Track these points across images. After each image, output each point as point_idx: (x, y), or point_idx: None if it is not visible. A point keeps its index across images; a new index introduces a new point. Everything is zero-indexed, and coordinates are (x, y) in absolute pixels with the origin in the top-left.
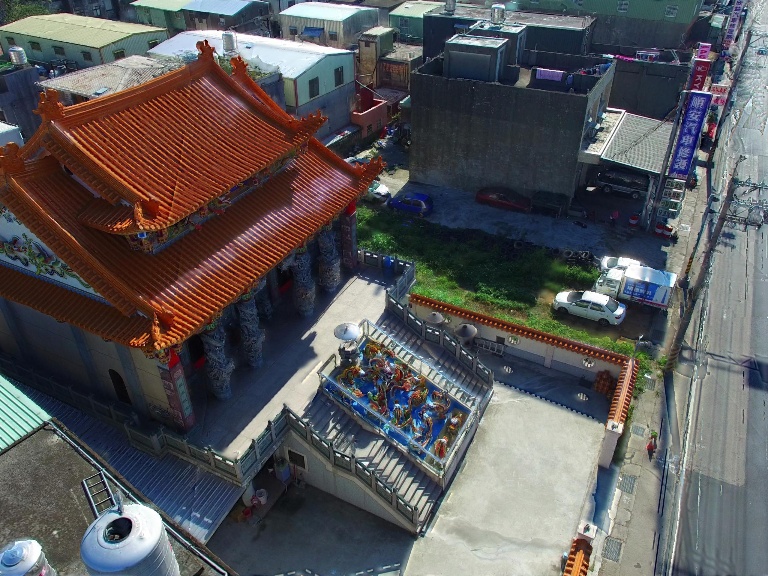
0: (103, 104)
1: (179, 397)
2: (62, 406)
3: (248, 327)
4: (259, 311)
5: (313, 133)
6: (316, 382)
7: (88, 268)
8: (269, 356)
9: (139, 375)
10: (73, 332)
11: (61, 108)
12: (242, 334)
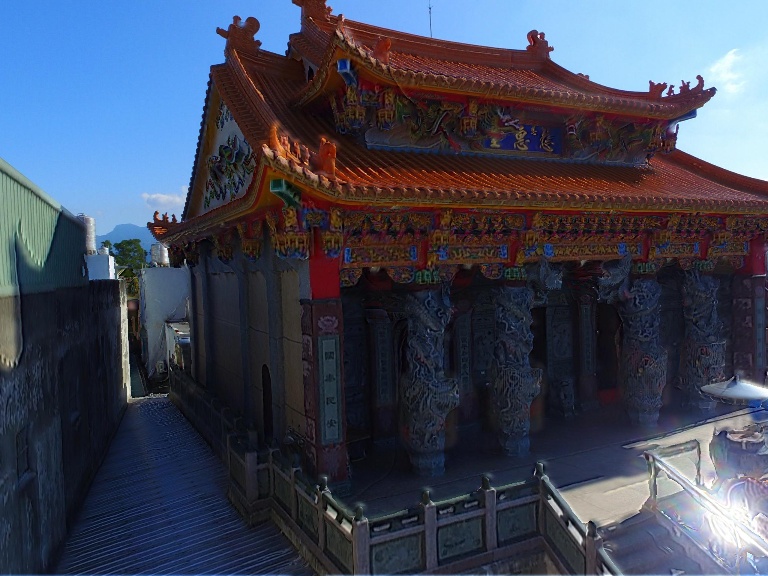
0: (384, 35)
1: (319, 382)
2: (199, 443)
3: (507, 345)
4: (549, 397)
5: (686, 107)
6: (640, 498)
7: (261, 129)
8: (545, 449)
9: (285, 356)
10: (239, 296)
11: (328, 11)
12: (494, 361)
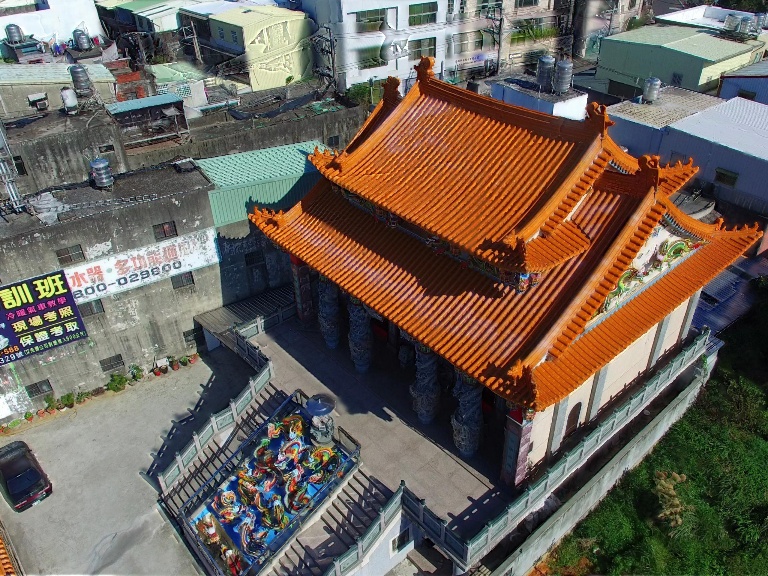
0: (461, 95)
1: None
2: None
3: None
4: None
5: None
6: None
7: None
8: (369, 377)
9: None
10: None
11: None
12: None
